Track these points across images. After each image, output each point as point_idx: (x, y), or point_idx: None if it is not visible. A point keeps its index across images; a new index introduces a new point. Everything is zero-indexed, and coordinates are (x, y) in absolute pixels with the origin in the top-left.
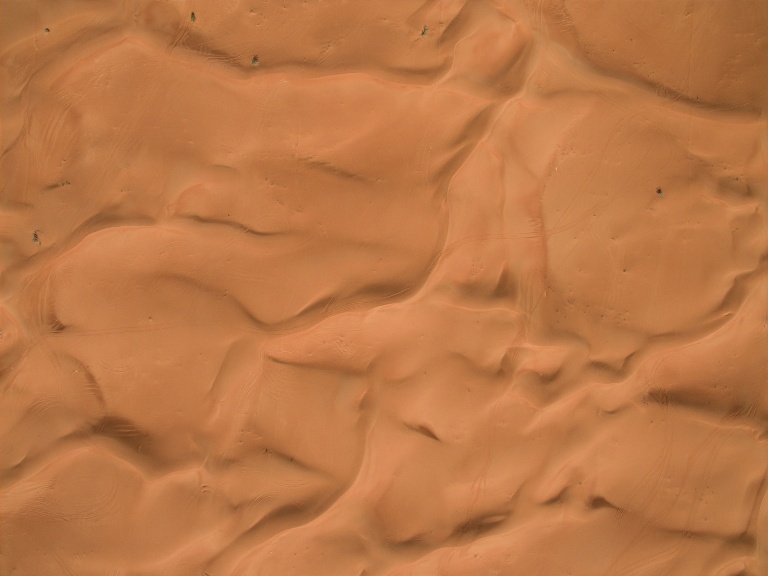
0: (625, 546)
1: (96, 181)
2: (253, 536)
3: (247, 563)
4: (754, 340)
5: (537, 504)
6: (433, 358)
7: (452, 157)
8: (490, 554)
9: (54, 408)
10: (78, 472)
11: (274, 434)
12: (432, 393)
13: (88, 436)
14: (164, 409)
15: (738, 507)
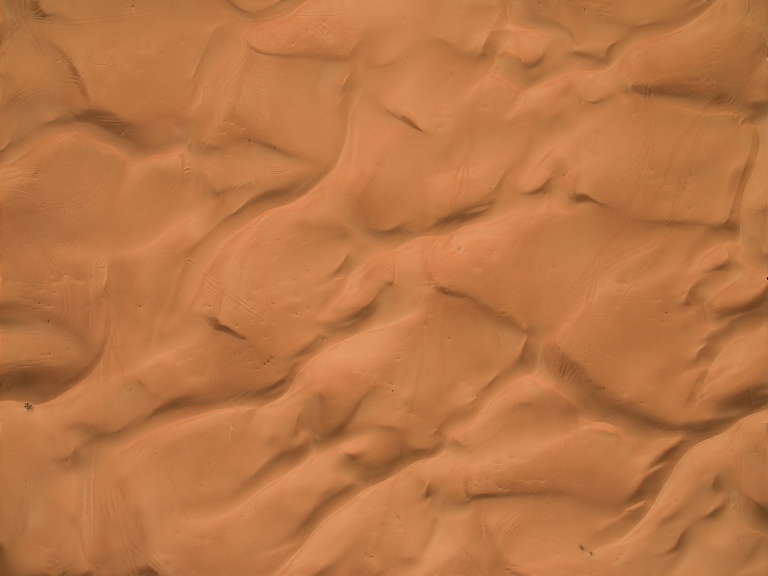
0: (608, 238)
1: None
2: (236, 219)
3: (230, 250)
4: (737, 30)
5: (520, 194)
6: (415, 42)
7: None
8: (473, 248)
9: (37, 96)
10: (61, 160)
11: (257, 125)
12: (414, 78)
13: (71, 122)
14: (147, 98)
15: (721, 194)
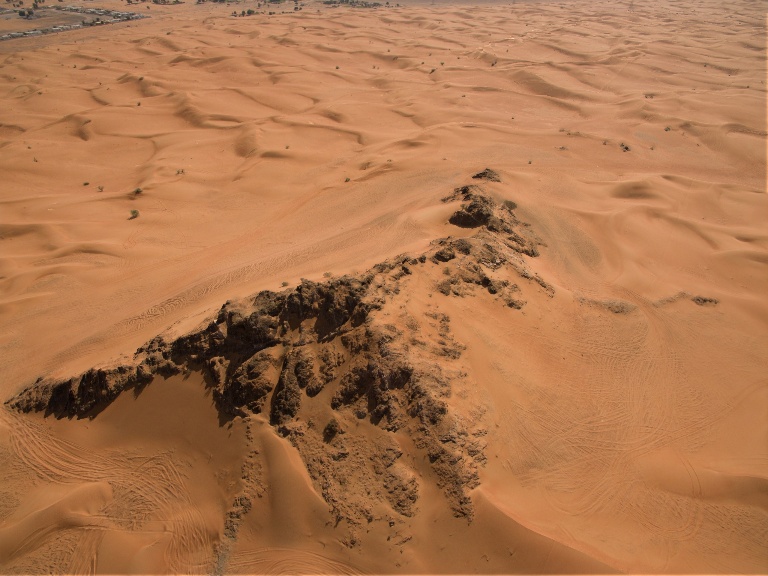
0: None
1: None
2: None
3: None
4: None
5: None
6: None
7: (640, 48)
8: None
9: None
10: None
11: None
12: None
13: None
14: None
15: None
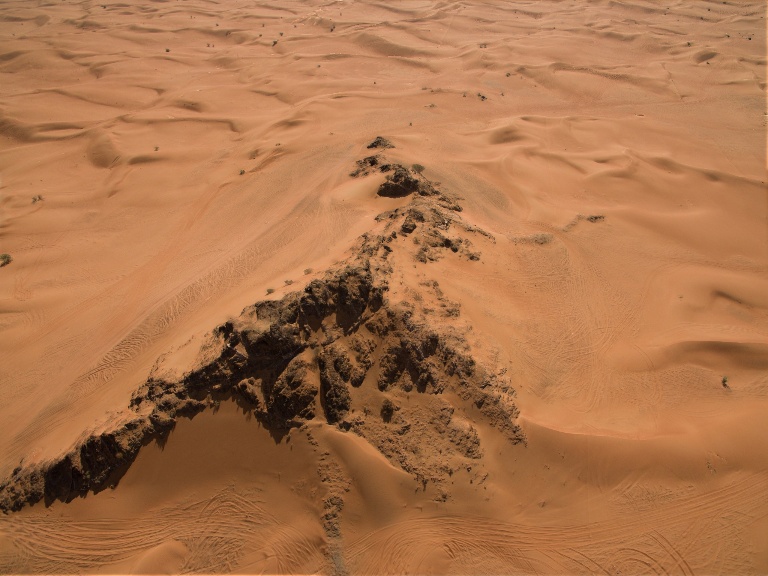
0: None
1: (561, 6)
2: None
3: None
4: None
5: None
6: None
7: None
8: None
9: None
10: None
11: None
12: None
13: None
14: None
15: None
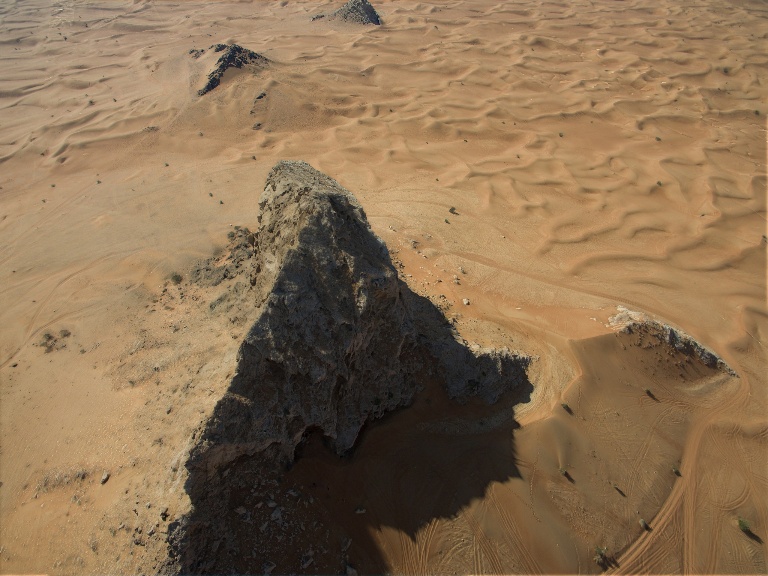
0: None
1: None
2: None
3: None
4: None
5: None
6: None
7: None
8: None
9: None
10: None
11: None
12: None
13: None
14: None
15: None
